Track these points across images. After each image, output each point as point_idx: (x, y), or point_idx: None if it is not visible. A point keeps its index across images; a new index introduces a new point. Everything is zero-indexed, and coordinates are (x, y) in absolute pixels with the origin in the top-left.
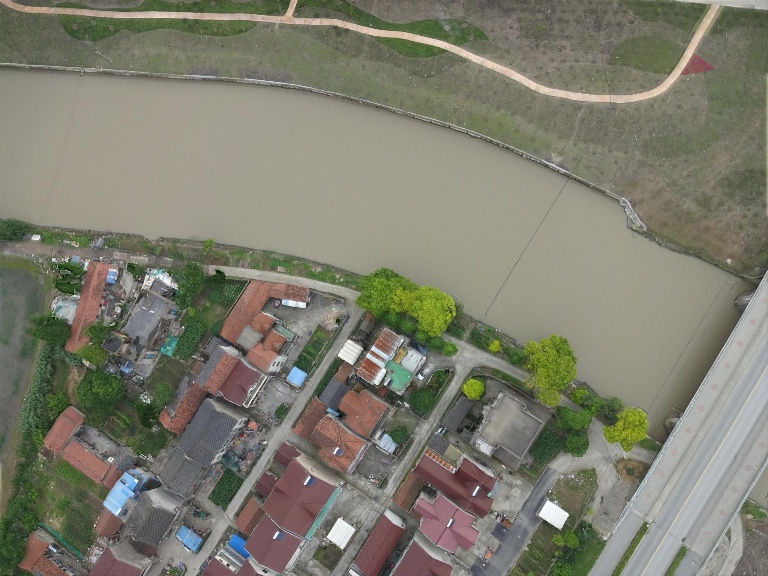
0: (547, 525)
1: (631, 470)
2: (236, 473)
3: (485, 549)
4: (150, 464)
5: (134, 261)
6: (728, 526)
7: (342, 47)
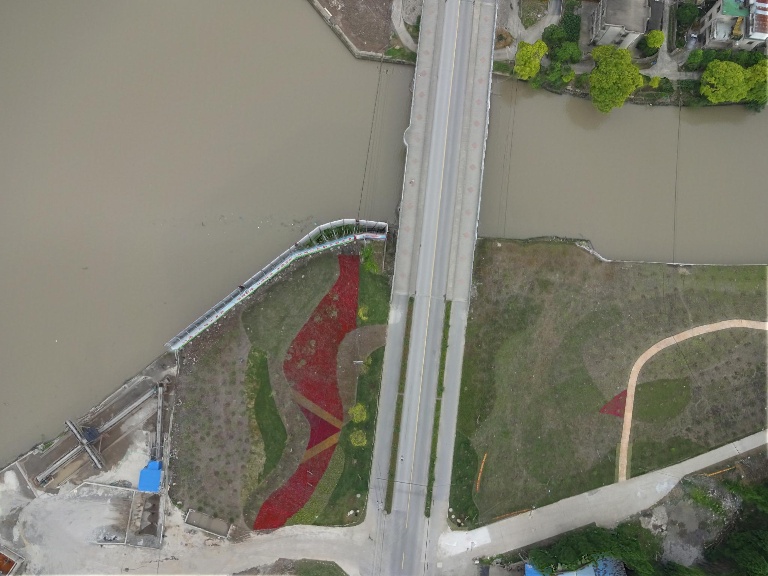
0: None
1: (500, 39)
2: None
3: None
4: None
5: None
6: None
7: None
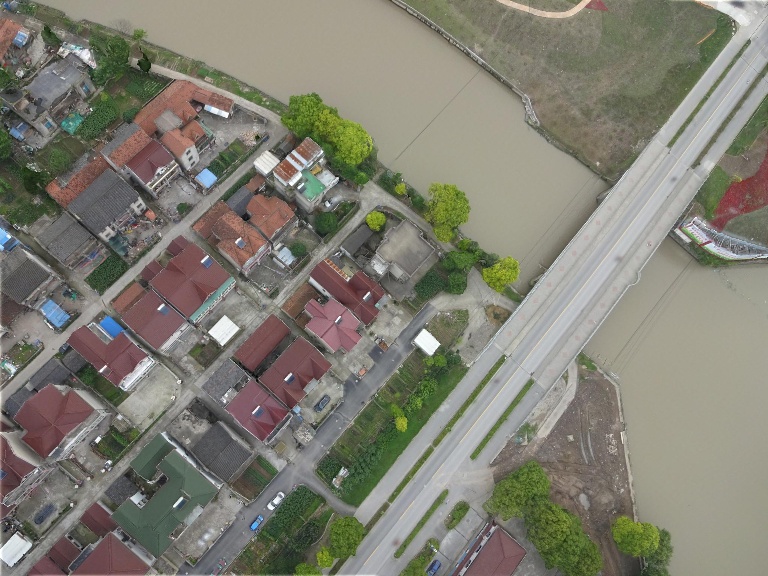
0: (419, 352)
1: (498, 315)
2: (122, 257)
3: (360, 366)
4: (23, 235)
5: None
6: (568, 365)
7: None
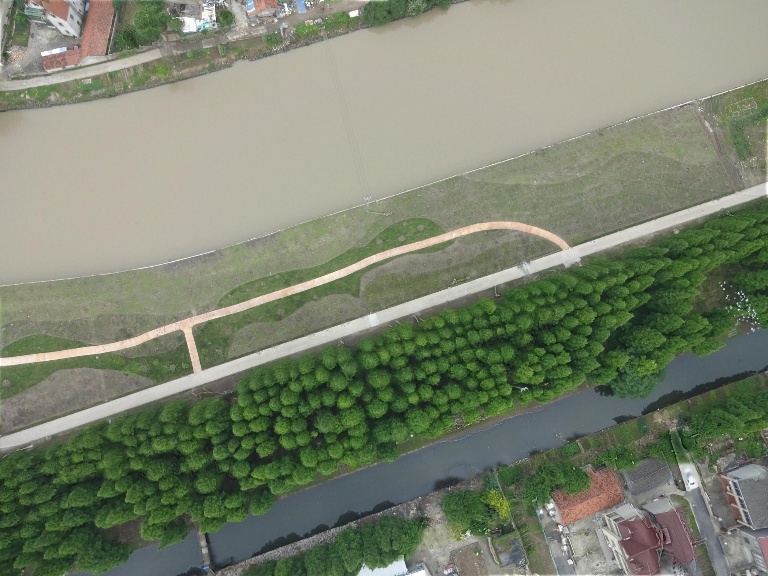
0: None
1: None
2: None
3: None
4: None
5: (241, 31)
6: None
7: (115, 320)
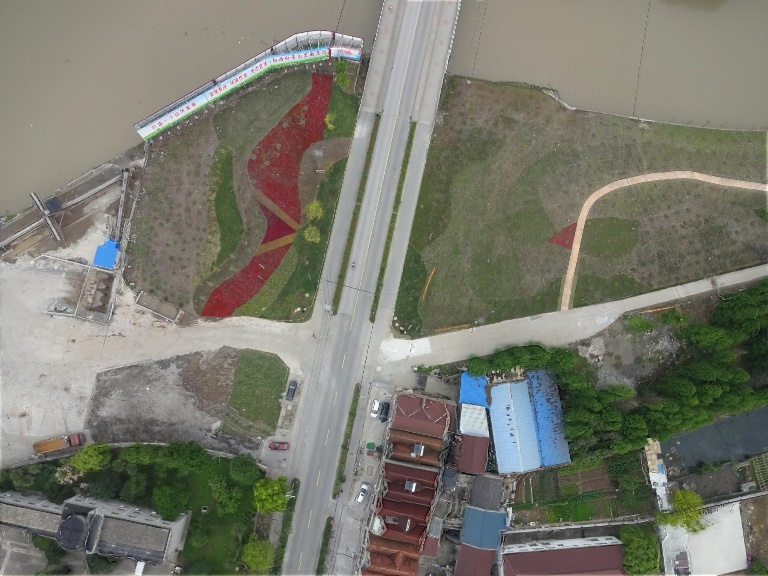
0: None
1: None
2: None
3: None
4: None
5: None
6: None
7: None
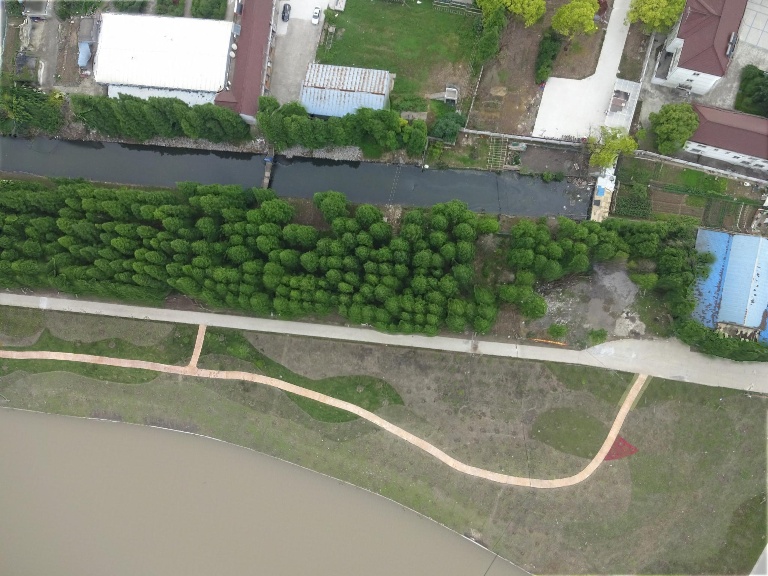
0: None
1: None
2: None
3: None
4: None
5: None
6: None
7: (250, 403)
